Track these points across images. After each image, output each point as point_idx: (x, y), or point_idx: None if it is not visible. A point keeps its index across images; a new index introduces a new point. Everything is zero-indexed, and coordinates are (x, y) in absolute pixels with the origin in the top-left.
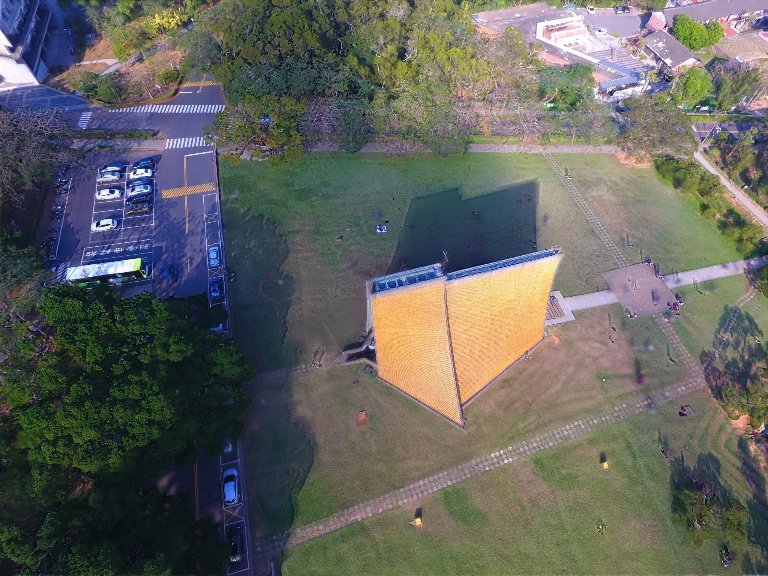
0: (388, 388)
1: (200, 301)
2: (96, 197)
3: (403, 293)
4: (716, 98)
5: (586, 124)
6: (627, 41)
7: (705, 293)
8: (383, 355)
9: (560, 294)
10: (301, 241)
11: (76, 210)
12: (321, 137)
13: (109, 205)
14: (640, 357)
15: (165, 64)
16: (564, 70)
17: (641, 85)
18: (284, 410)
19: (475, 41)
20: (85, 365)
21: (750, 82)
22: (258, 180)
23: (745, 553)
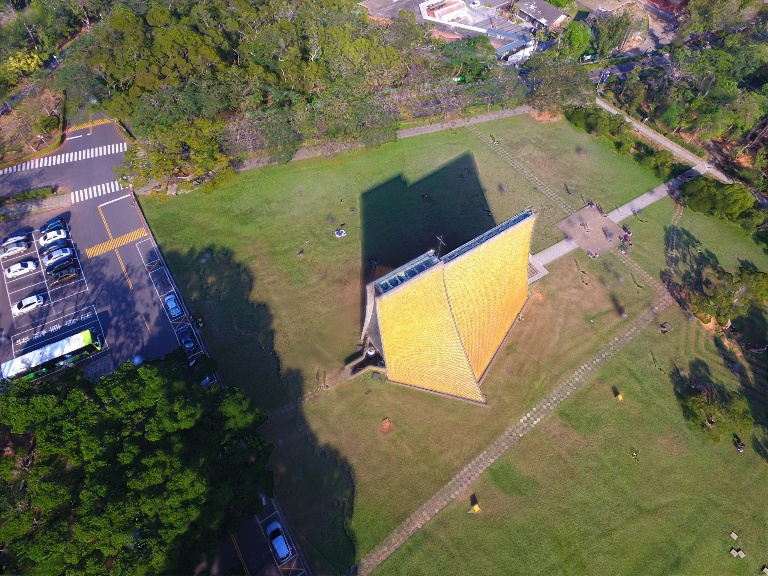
0: (402, 388)
1: (179, 357)
2: (6, 276)
3: (406, 288)
4: (597, 46)
5: (500, 90)
6: (500, 9)
7: (645, 220)
8: (392, 357)
9: None
10: (261, 266)
11: None
12: None
13: (25, 281)
14: (613, 291)
15: (42, 110)
16: (464, 43)
17: (529, 46)
18: (306, 444)
19: (374, 29)
20: (85, 465)
21: (623, 26)
22: (192, 214)
23: (752, 435)
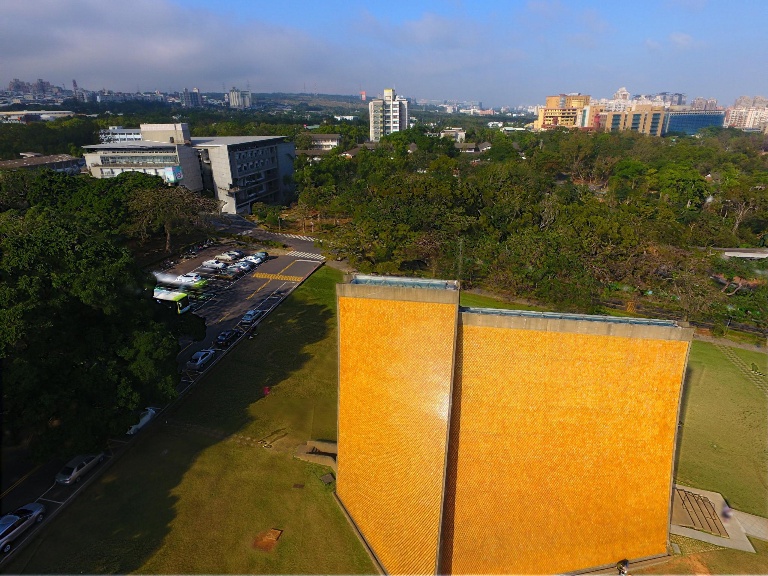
0: (338, 515)
1: None
2: (203, 263)
3: (387, 302)
4: None
5: None
6: None
7: None
8: (346, 437)
9: (721, 499)
10: None
11: (182, 268)
12: (428, 275)
13: (208, 270)
14: None
15: None
16: (750, 262)
17: None
18: (178, 474)
19: None
20: (3, 265)
21: None
22: None
23: None
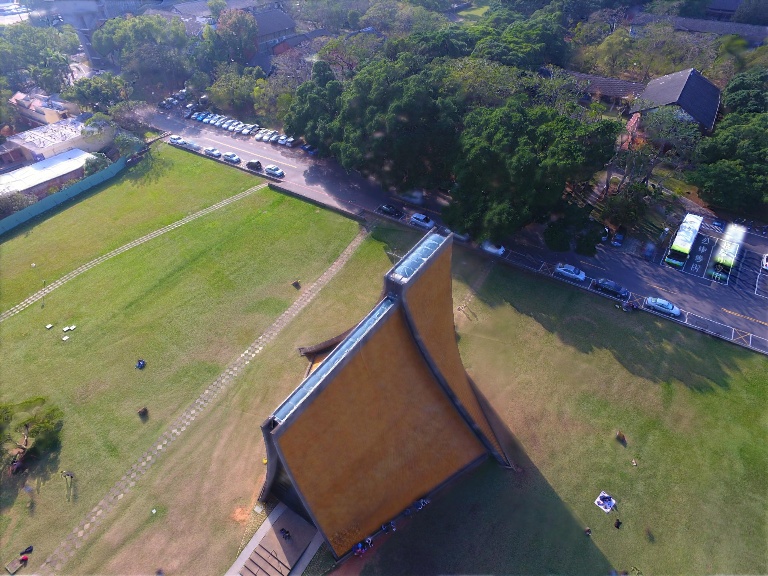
0: None
1: (585, 242)
2: None
3: None
4: None
5: None
6: None
7: None
8: None
9: None
10: (645, 396)
11: None
12: None
13: None
14: None
15: None
16: None
17: None
18: None
19: None
20: None
21: None
22: None
23: None
